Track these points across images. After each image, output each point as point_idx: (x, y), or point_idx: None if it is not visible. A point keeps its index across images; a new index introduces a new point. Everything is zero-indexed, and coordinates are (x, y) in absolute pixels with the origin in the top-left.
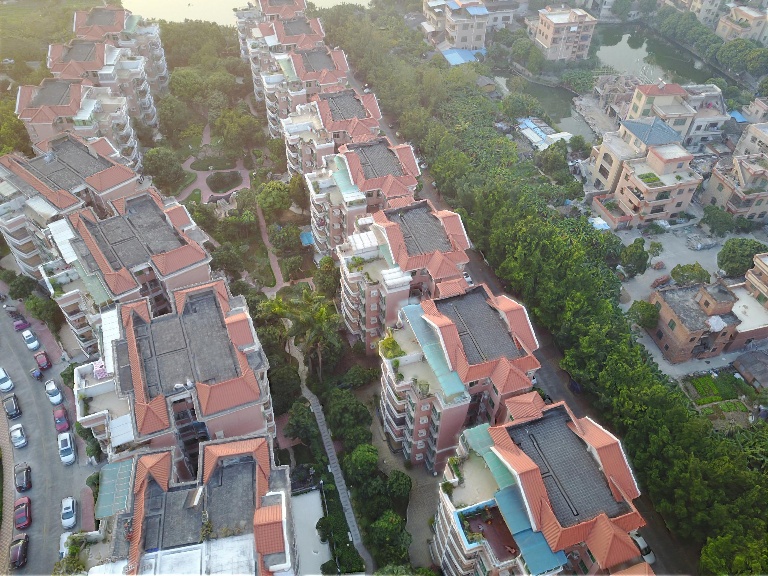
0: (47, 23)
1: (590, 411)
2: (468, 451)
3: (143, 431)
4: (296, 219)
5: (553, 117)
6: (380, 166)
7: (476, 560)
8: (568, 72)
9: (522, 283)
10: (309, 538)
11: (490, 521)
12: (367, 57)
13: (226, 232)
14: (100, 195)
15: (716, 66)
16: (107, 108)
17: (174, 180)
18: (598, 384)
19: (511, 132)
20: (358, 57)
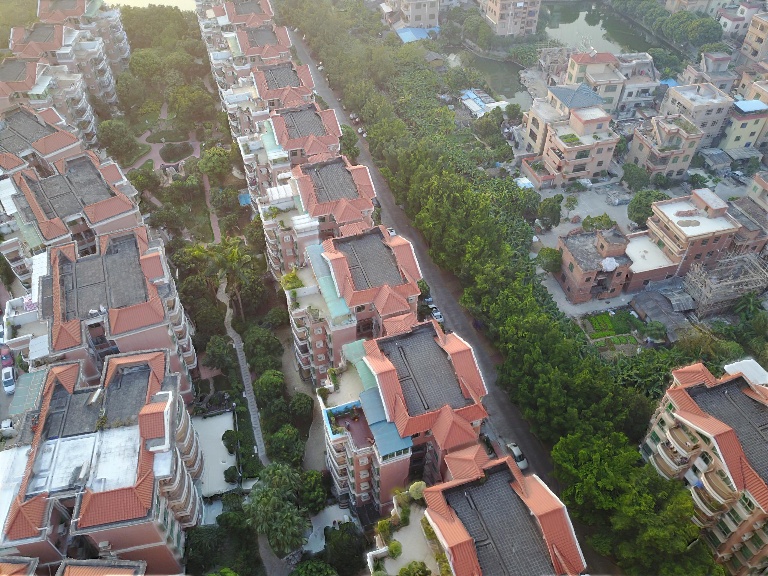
0: (22, 13)
1: (488, 344)
2: (345, 363)
3: (57, 347)
4: (239, 184)
5: (507, 92)
6: (305, 128)
7: (345, 453)
8: (515, 46)
9: (431, 231)
10: (219, 451)
11: (357, 419)
12: (320, 36)
13: (172, 196)
14: (44, 158)
15: (663, 38)
16: (62, 84)
17: (126, 150)
18: (490, 317)
19: (453, 103)
20: (312, 36)
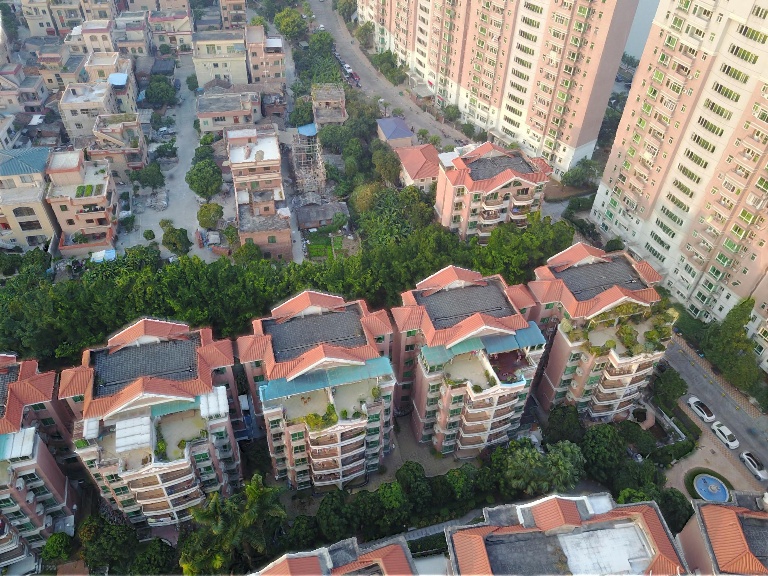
0: None
1: None
2: None
3: None
4: None
5: None
6: None
7: None
8: None
9: (212, 315)
10: None
11: (498, 368)
12: None
13: None
14: None
15: None
16: None
17: None
18: None
19: None
20: None
